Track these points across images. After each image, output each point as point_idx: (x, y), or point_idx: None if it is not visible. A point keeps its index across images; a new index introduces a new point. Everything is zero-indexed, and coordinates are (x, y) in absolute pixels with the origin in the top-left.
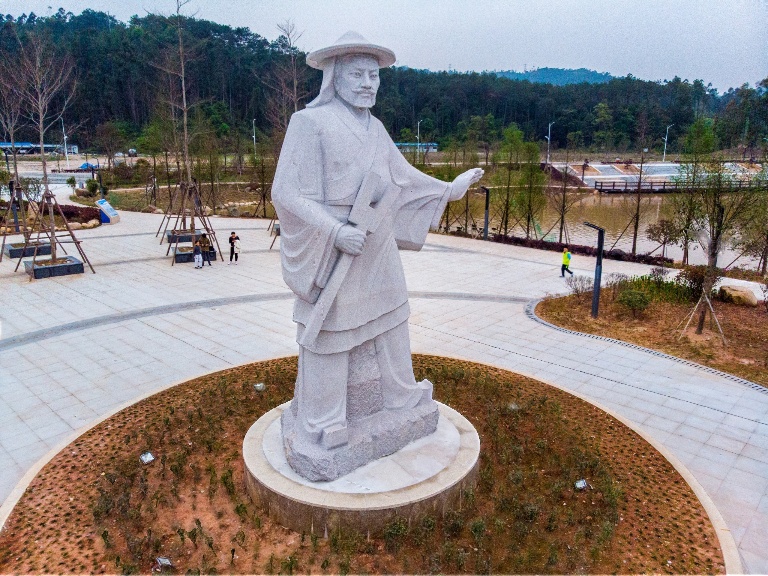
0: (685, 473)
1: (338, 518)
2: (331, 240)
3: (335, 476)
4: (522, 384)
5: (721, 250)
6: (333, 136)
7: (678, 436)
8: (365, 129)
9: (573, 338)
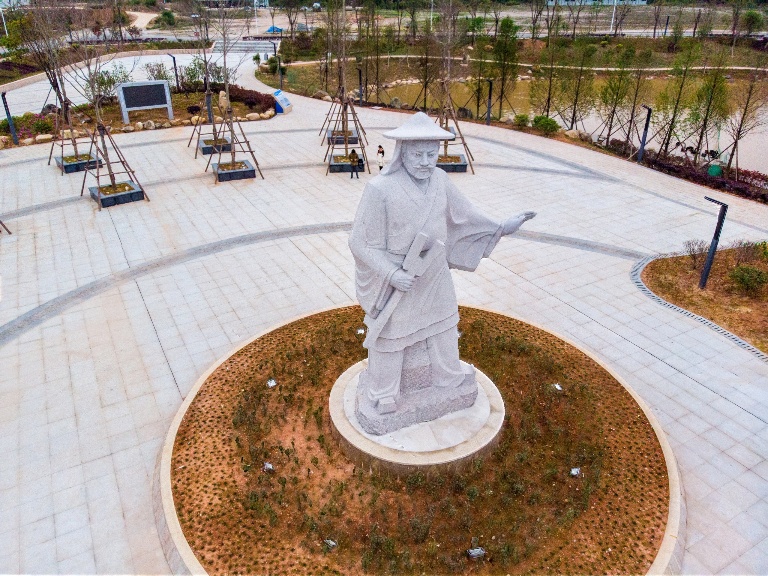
0: (674, 480)
1: (379, 463)
2: (387, 281)
3: (384, 432)
4: (578, 363)
5: None
6: (395, 203)
7: (702, 439)
8: (423, 193)
9: (663, 312)
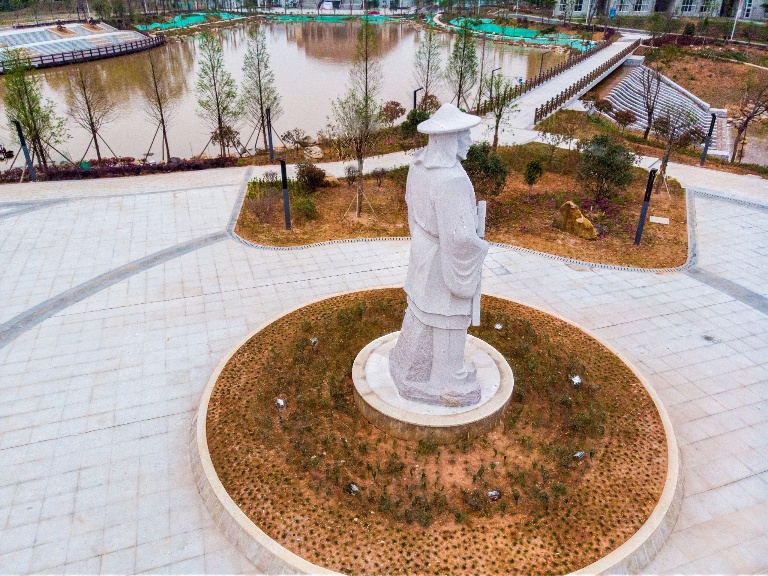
0: (503, 297)
1: None
2: None
3: None
4: (378, 296)
5: (366, 158)
6: None
7: None
8: None
9: (313, 251)
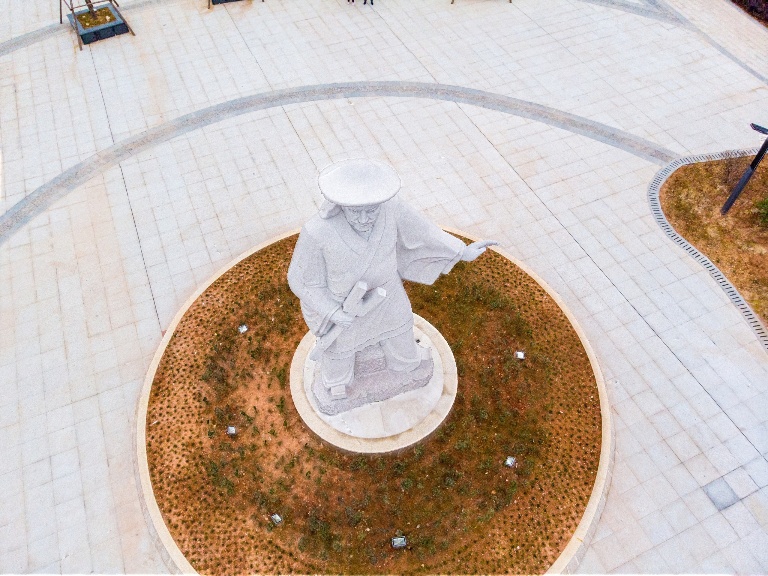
0: (601, 477)
1: (327, 443)
2: (326, 319)
3: (336, 413)
4: (552, 322)
5: None
6: (332, 253)
7: (649, 423)
8: (365, 240)
9: (668, 248)
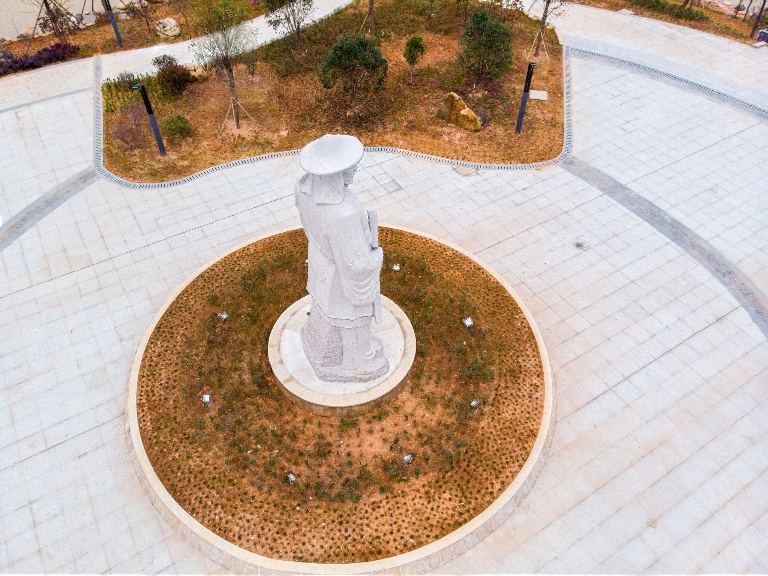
0: (398, 227)
1: None
2: None
3: None
4: (277, 244)
5: (235, 66)
6: None
7: None
8: None
9: (198, 185)
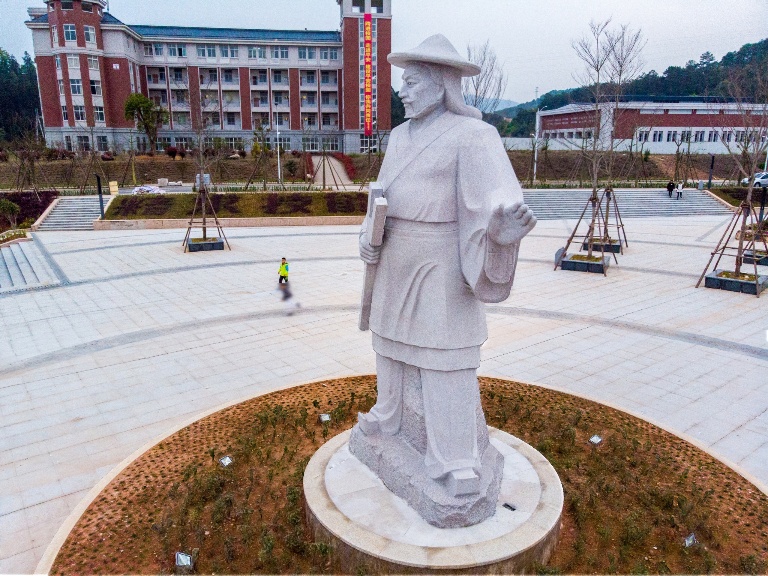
0: None
1: None
2: None
3: None
4: None
5: None
6: None
7: None
8: (410, 141)
9: None
